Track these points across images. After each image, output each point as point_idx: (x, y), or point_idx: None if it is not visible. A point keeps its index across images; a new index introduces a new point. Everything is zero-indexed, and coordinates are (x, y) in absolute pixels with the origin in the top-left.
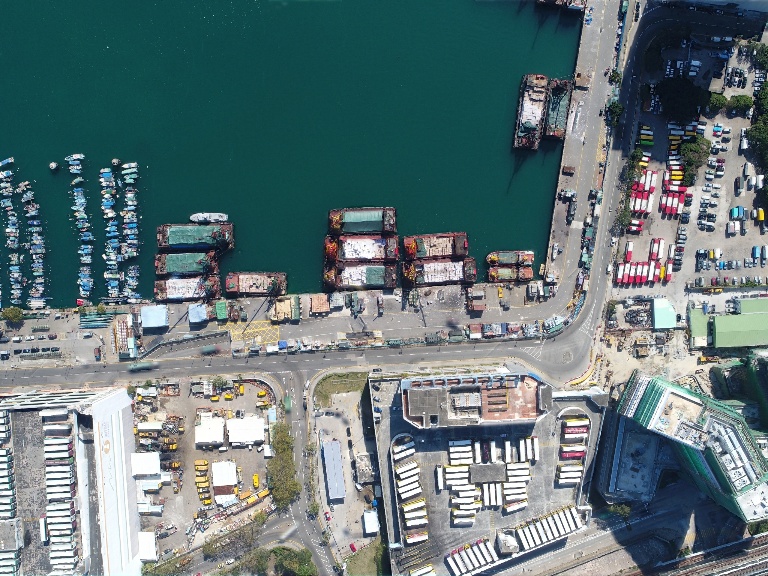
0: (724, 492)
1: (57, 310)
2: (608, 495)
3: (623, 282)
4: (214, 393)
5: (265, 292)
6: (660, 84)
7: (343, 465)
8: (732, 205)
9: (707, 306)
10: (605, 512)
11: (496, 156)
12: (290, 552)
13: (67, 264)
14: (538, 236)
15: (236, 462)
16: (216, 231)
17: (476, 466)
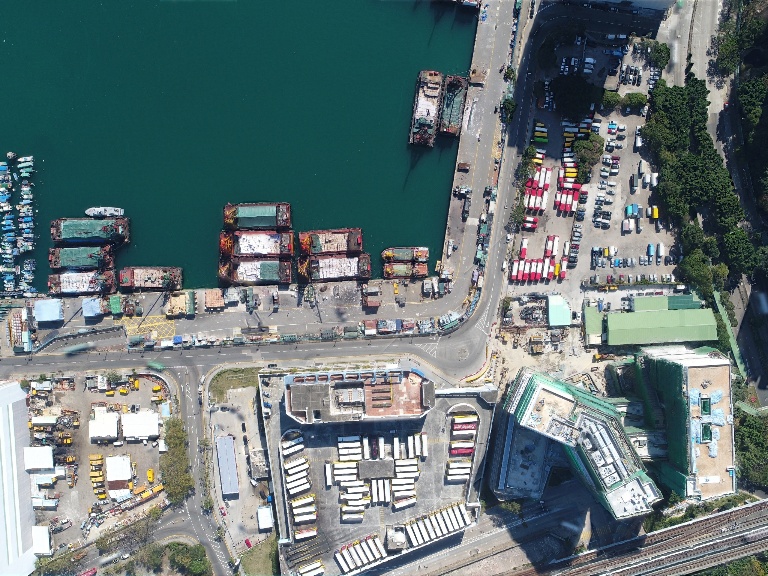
0: (596, 489)
1: None
2: (498, 492)
3: (518, 279)
4: (108, 387)
5: (160, 287)
6: (553, 81)
7: (238, 460)
8: (627, 203)
9: (602, 304)
10: (501, 509)
11: (392, 152)
12: (183, 547)
13: None
14: (434, 232)
15: (131, 457)
16: (107, 225)
17: (364, 462)
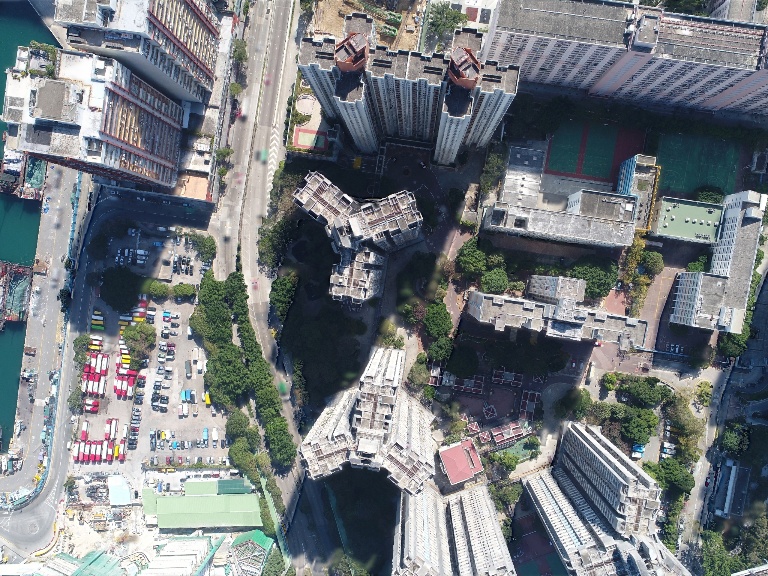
0: None
1: None
2: None
3: None
4: None
5: None
6: (103, 274)
7: None
8: (184, 387)
9: (162, 484)
10: None
11: None
12: None
13: None
14: (7, 412)
15: None
16: None
17: None
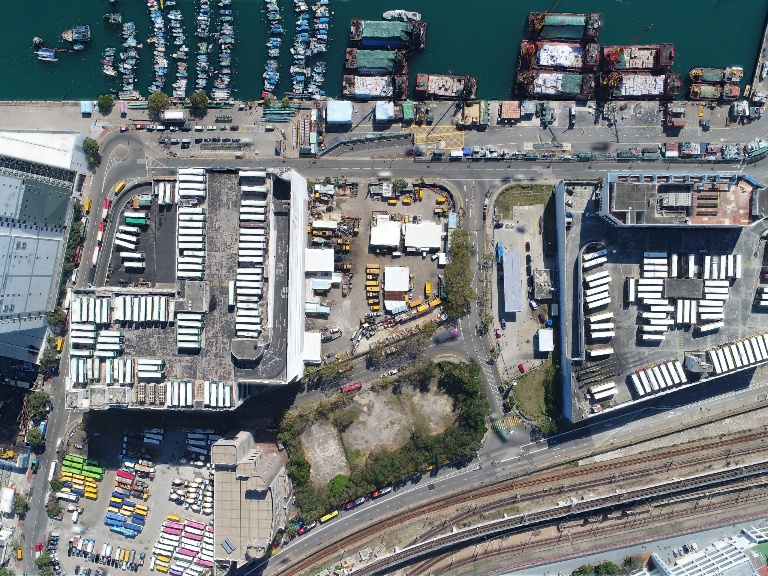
0: None
1: (241, 101)
2: None
3: None
4: (393, 195)
5: (453, 95)
6: None
7: None
8: None
9: None
10: None
11: None
12: (460, 363)
13: (254, 57)
14: (746, 55)
15: None
16: None
17: (671, 280)
